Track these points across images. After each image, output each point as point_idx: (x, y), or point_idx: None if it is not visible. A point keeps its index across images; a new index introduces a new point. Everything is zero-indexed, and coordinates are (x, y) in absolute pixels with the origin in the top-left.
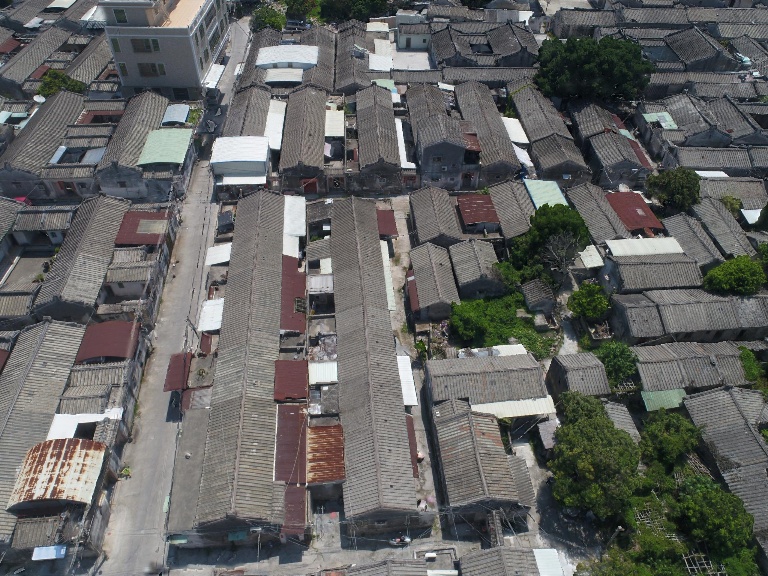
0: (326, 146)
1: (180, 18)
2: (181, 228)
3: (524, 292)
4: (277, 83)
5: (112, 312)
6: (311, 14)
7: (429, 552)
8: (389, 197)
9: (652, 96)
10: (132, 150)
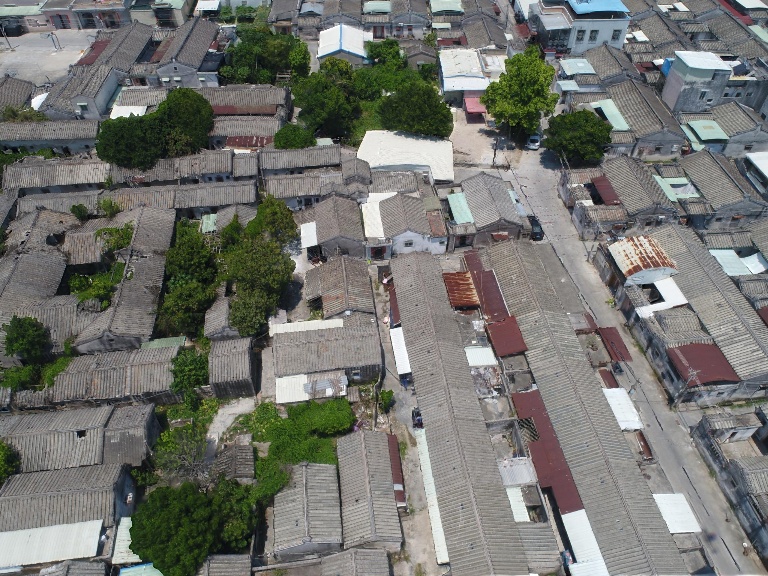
0: None
1: None
2: None
3: None
4: None
5: (739, 416)
6: None
7: None
8: None
9: None
10: None
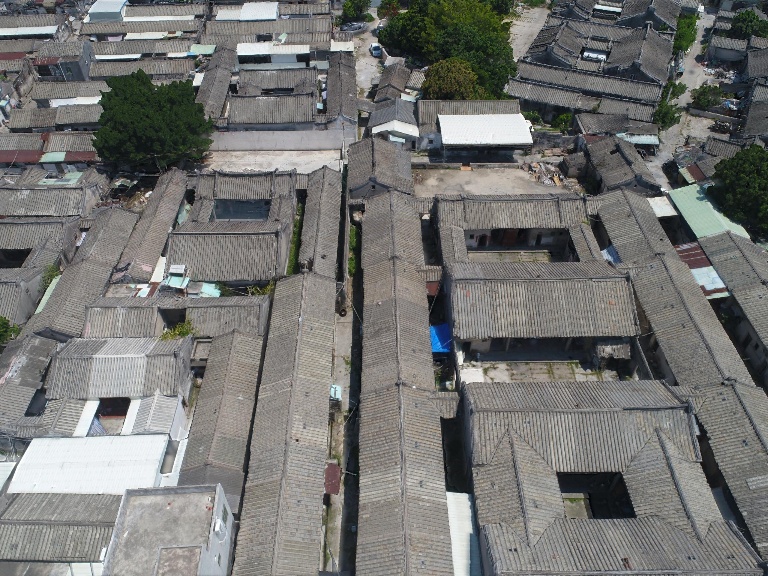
0: None
1: None
2: None
3: None
4: None
5: None
6: None
7: None
8: None
9: None
10: None
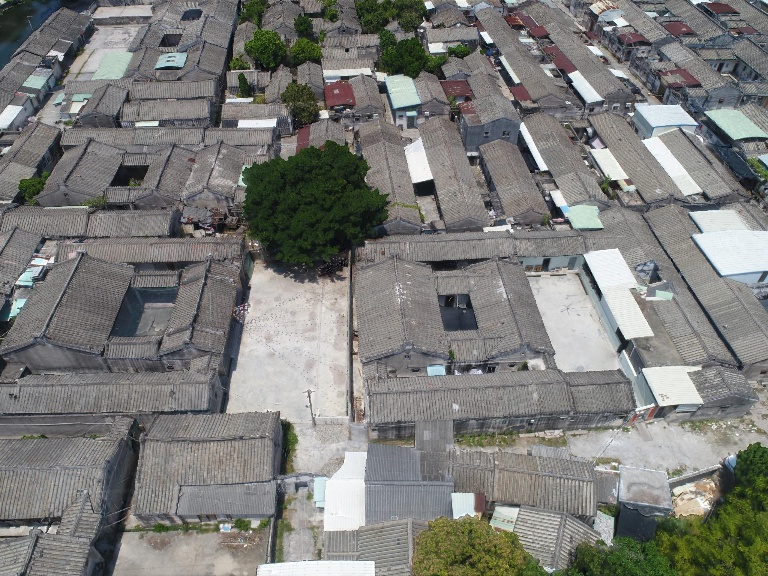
0: None
1: None
2: None
3: None
4: None
5: None
6: None
7: (469, 9)
8: None
9: None
10: (759, 119)
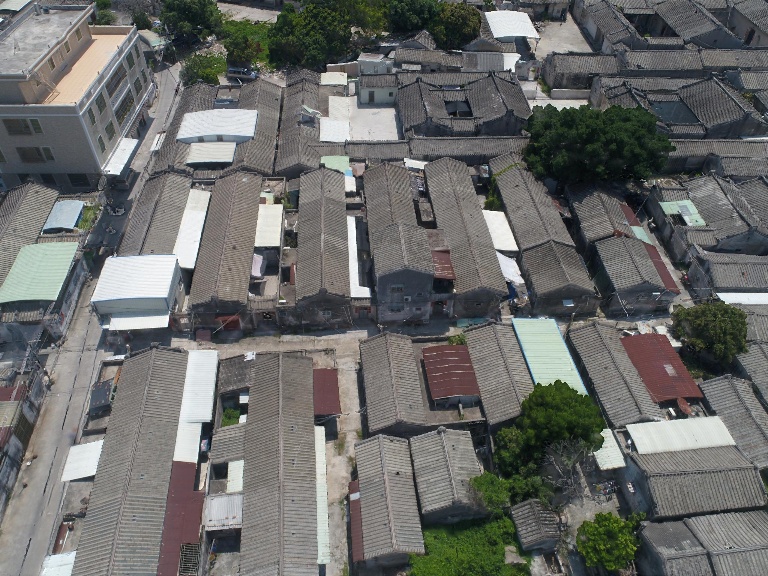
0: (255, 260)
1: (72, 87)
2: (50, 395)
3: (515, 521)
4: (201, 164)
5: None
6: (258, 57)
7: None
8: (336, 334)
9: (667, 170)
10: None
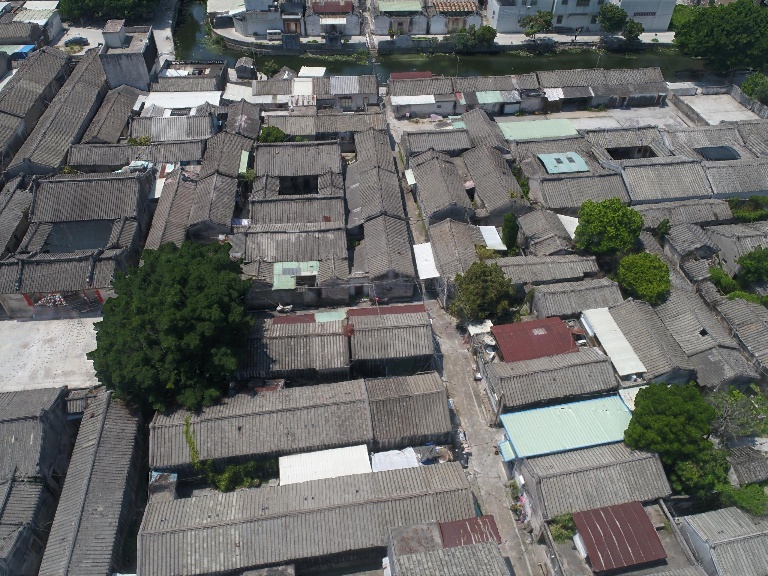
0: None
1: None
2: None
3: None
4: None
5: None
6: None
7: None
8: None
9: None
10: None
